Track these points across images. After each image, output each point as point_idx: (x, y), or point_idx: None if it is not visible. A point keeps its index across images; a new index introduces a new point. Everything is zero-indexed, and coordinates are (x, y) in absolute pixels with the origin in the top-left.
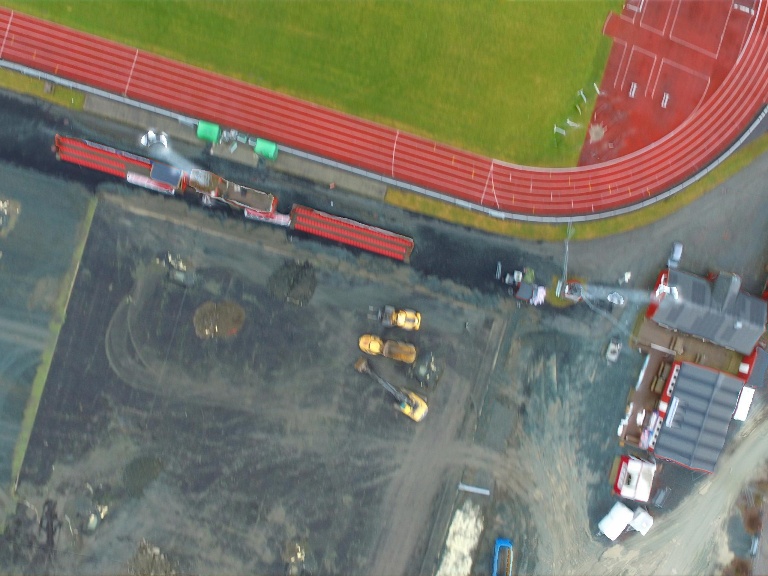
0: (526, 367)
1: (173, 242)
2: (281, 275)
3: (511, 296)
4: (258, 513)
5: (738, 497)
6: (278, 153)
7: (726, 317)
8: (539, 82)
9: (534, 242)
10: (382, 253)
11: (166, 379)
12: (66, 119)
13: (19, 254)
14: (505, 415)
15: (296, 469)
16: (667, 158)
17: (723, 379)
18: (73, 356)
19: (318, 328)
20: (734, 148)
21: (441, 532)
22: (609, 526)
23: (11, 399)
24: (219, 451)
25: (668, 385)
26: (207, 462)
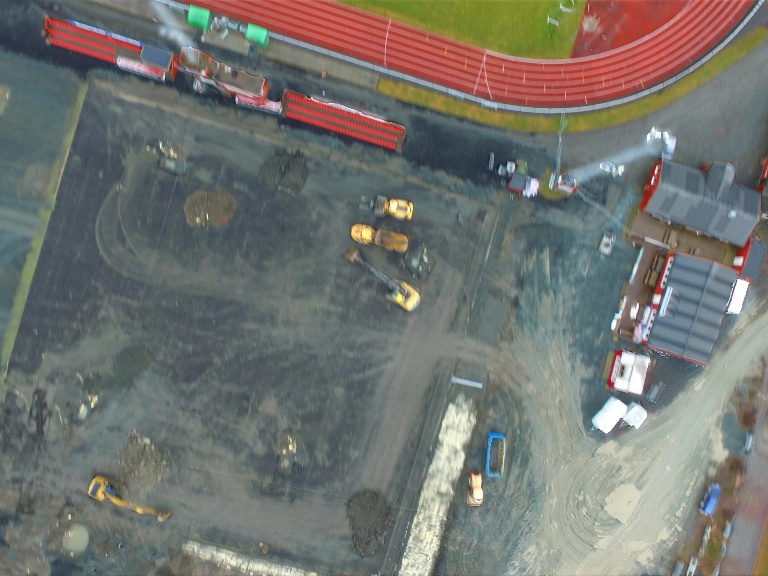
0: (519, 260)
1: (164, 129)
2: (272, 163)
3: (504, 188)
4: (249, 404)
5: (732, 394)
6: (269, 41)
7: (720, 206)
8: None
9: (527, 134)
10: (374, 142)
11: (157, 268)
12: (56, 4)
13: (8, 139)
14: (498, 308)
15: (288, 360)
16: (661, 51)
17: (717, 268)
18: (63, 243)
19: (310, 218)
20: (728, 40)
21: (434, 425)
22: (602, 419)
23: (0, 286)
24: (210, 341)
25: (662, 278)
26: (198, 352)
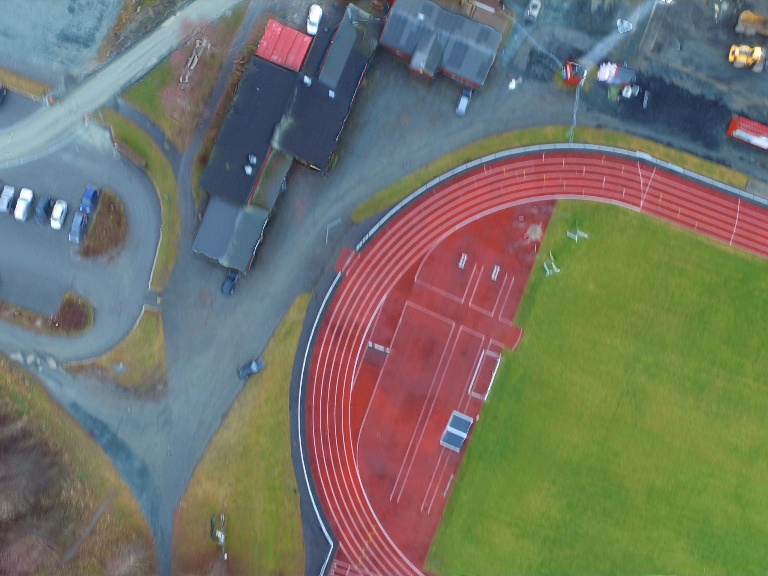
0: None
1: None
2: None
3: None
4: None
5: None
6: None
7: (434, 27)
8: (591, 285)
9: (605, 127)
10: (760, 125)
11: None
12: None
13: None
14: None
15: None
16: (464, 203)
17: None
18: None
19: None
20: (398, 208)
21: None
22: None
23: None
24: None
25: None
26: None
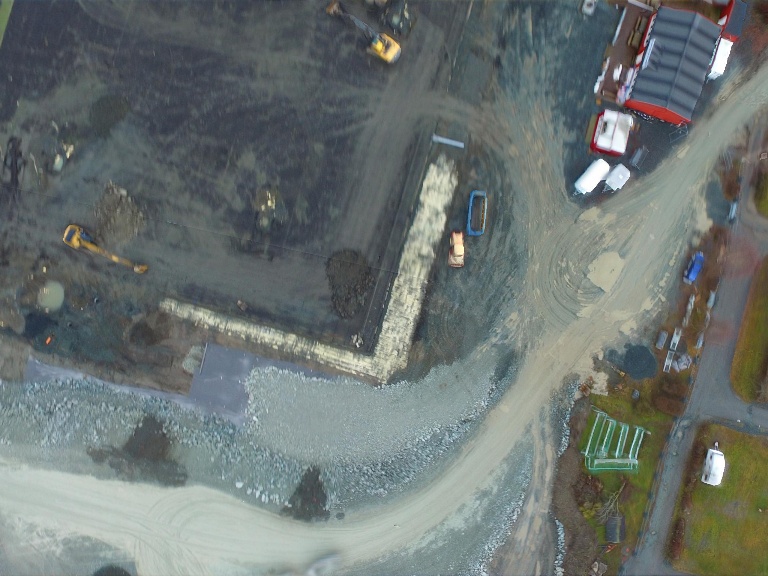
0: (501, 18)
1: None
2: None
3: None
4: (228, 158)
5: (716, 162)
6: None
7: None
8: None
9: None
10: None
11: (134, 16)
12: None
13: None
14: (480, 67)
15: (266, 114)
16: None
17: (700, 20)
18: None
19: None
20: None
21: (414, 184)
22: (585, 177)
23: None
24: (188, 92)
25: (645, 37)
26: (175, 103)
